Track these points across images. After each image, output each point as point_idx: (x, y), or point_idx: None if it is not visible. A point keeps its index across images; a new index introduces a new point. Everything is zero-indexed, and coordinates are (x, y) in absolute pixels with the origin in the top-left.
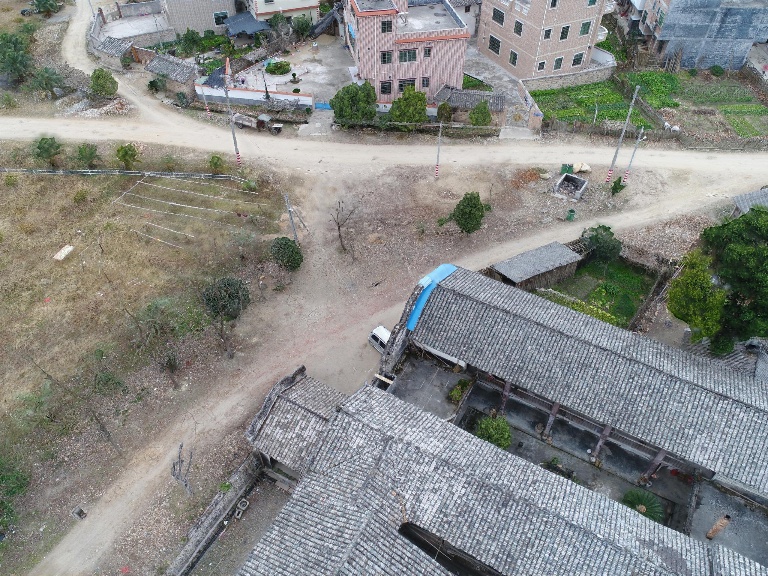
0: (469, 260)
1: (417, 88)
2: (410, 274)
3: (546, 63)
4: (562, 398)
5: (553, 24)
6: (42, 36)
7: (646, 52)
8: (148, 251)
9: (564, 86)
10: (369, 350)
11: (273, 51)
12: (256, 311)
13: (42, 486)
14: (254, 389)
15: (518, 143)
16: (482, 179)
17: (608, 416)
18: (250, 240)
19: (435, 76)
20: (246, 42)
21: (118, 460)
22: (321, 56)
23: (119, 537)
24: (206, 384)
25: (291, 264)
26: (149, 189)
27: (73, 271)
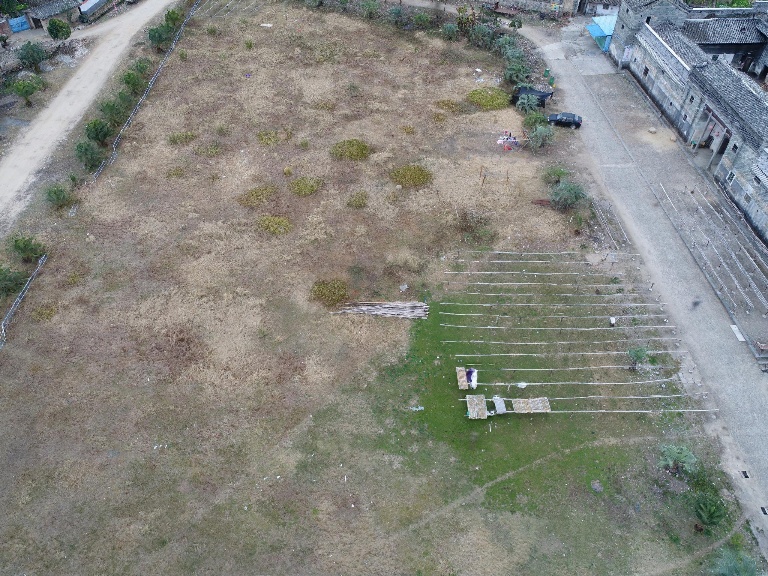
0: None
1: None
2: None
3: None
4: None
5: None
6: None
7: None
8: None
9: None
10: None
11: None
12: None
13: None
14: None
15: None
16: None
17: None
18: None
19: None
20: None
21: (388, 3)
22: None
23: None
24: None
25: None
26: None
27: None
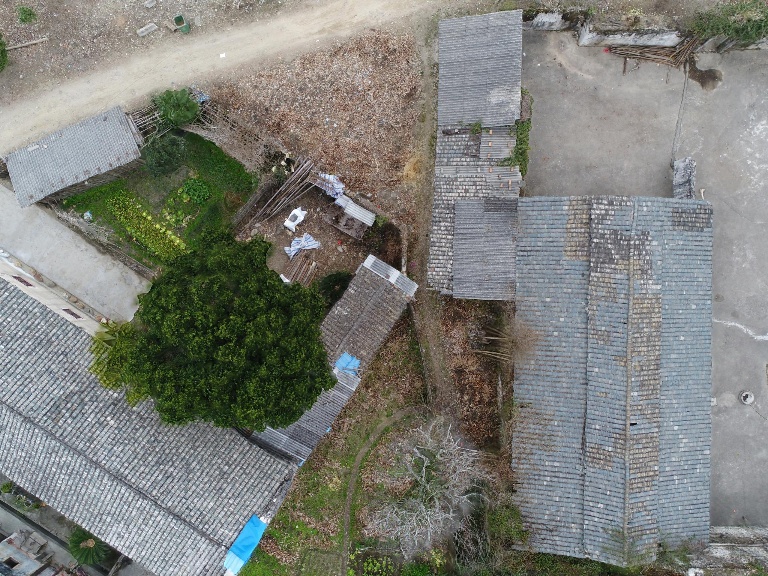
0: (3, 119)
1: None
2: None
3: None
4: None
5: None
6: None
7: None
8: None
9: None
10: None
11: None
12: None
13: None
14: None
15: None
16: None
17: (28, 483)
18: None
19: None
20: None
21: None
22: None
23: None
24: None
25: None
26: None
27: None
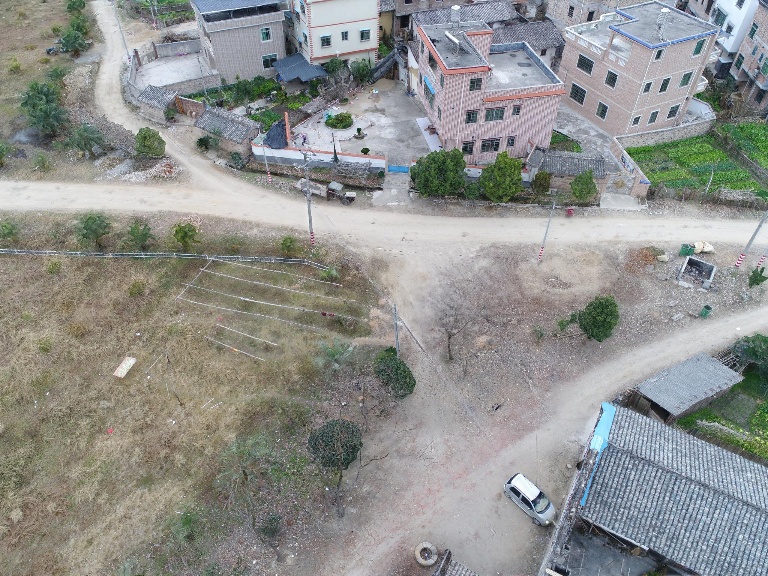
0: (599, 373)
1: (501, 148)
2: (534, 392)
3: (641, 117)
4: None
5: (654, 77)
6: (72, 80)
7: (740, 99)
8: (221, 361)
9: (659, 142)
10: (505, 503)
11: (330, 99)
12: None
13: None
14: (376, 562)
15: (623, 215)
16: (592, 262)
17: None
18: (346, 354)
19: (522, 135)
20: (298, 88)
21: None
22: (383, 105)
23: None
24: (316, 554)
25: (403, 391)
26: (213, 277)
27: (137, 390)
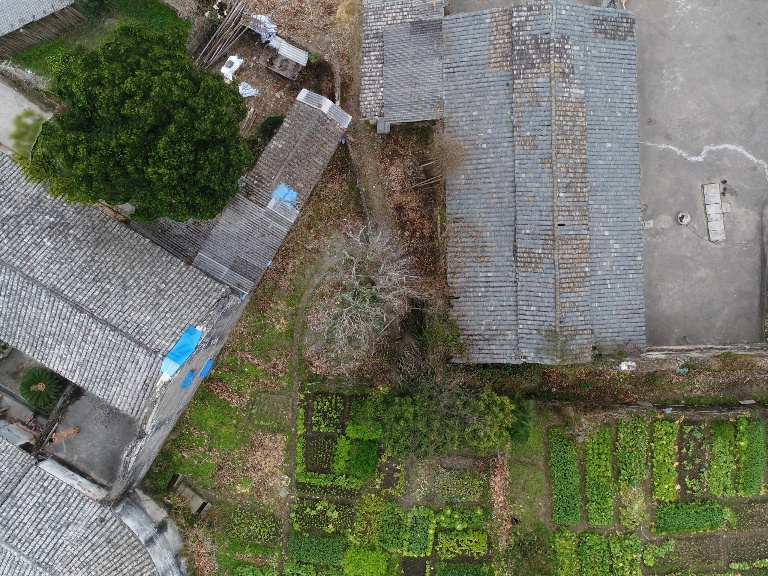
0: None
1: None
2: None
3: None
4: None
5: None
6: None
7: None
8: None
9: None
10: None
11: None
12: None
13: None
14: None
15: None
16: None
17: None
18: None
19: None
20: None
21: None
22: None
23: None
24: None
25: None
26: None
27: None
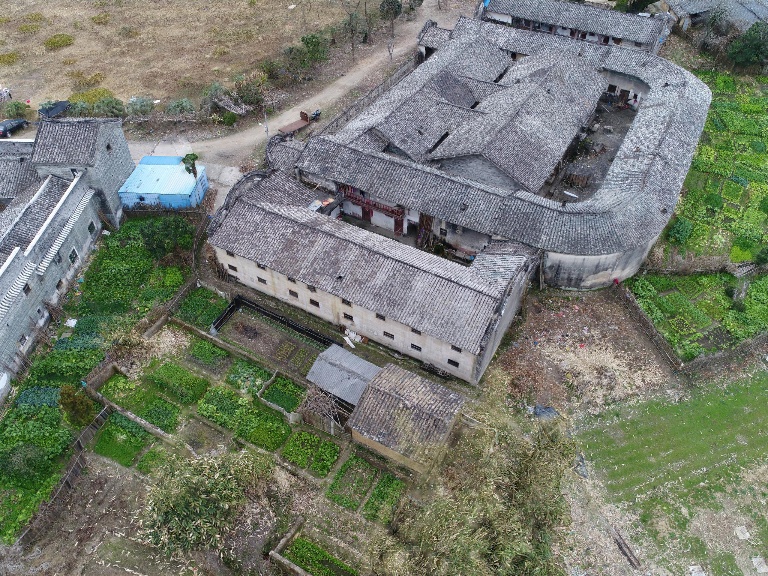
0: None
1: None
2: None
3: None
4: (556, 22)
5: None
6: None
7: None
8: None
9: None
10: None
11: None
12: (400, 27)
13: (321, 69)
14: (408, 46)
15: None
16: None
17: (576, 26)
18: None
19: None
20: None
21: (353, 63)
22: None
23: (363, 78)
24: (384, 45)
25: (418, 1)
26: None
27: None
